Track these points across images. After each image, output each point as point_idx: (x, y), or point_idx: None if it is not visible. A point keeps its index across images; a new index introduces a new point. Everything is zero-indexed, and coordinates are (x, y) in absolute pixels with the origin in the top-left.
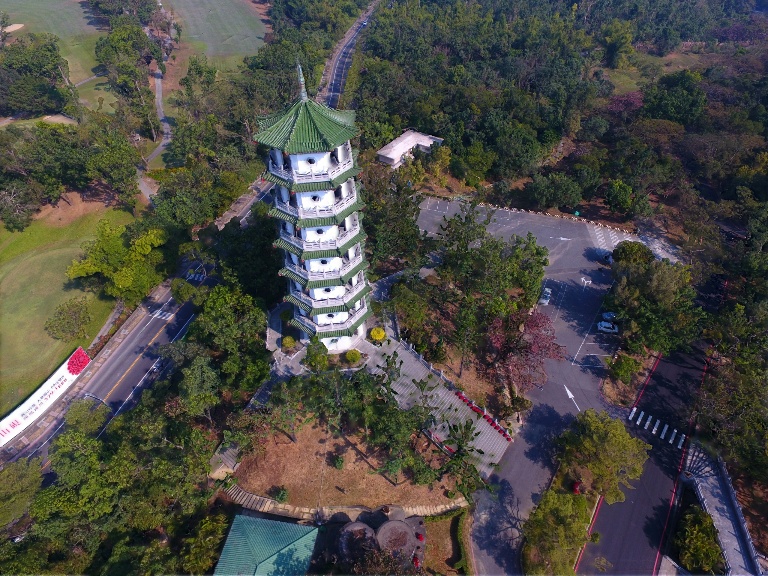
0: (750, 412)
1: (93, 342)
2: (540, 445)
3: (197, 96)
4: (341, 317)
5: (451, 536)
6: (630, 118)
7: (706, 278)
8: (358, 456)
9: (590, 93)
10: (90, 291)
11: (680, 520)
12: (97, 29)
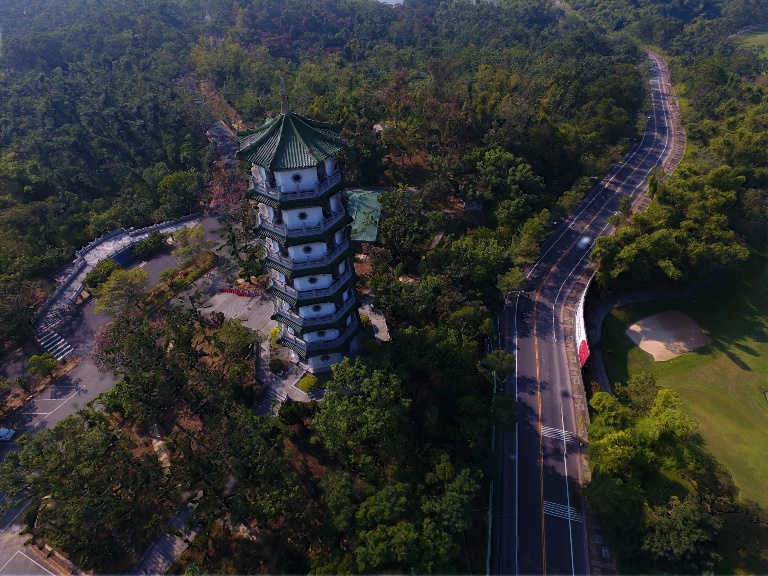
0: None
1: None
2: None
3: None
4: None
5: None
6: None
7: None
8: None
9: None
10: None
11: (104, 281)
12: None
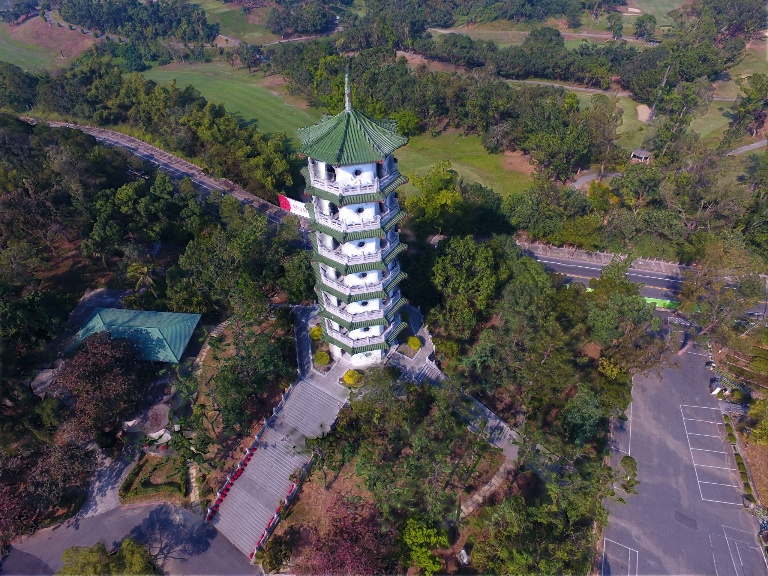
0: None
1: None
2: None
3: None
4: None
5: (168, 483)
6: None
7: None
8: None
9: None
10: None
11: None
12: None
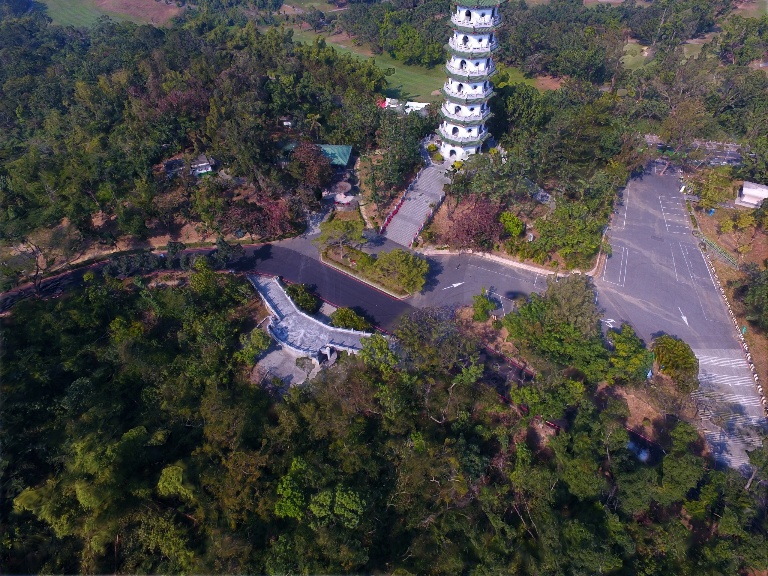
0: None
1: None
2: None
3: None
4: (448, 129)
5: None
6: None
7: None
8: None
9: None
10: None
11: None
12: None
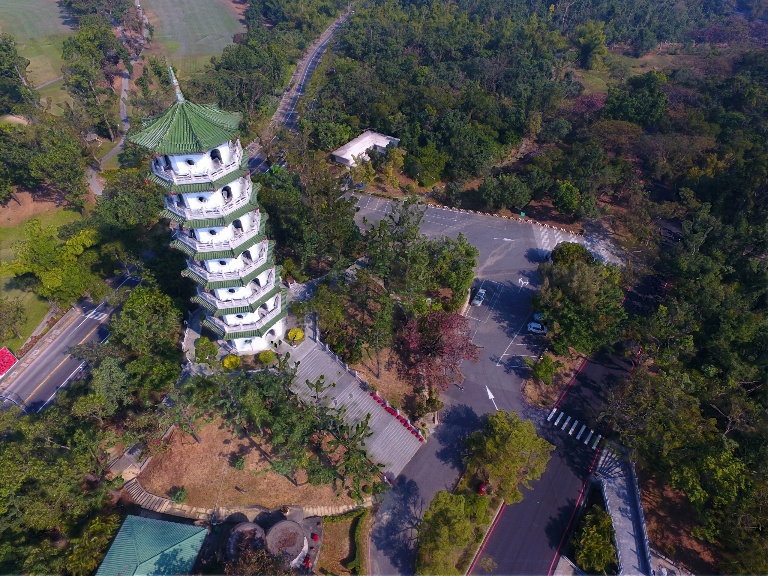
0: (653, 413)
1: (26, 342)
2: (453, 446)
3: (151, 96)
4: (251, 318)
5: (350, 536)
6: (592, 119)
7: (647, 279)
8: (262, 457)
9: (554, 94)
10: (30, 291)
11: (580, 520)
12: (71, 29)
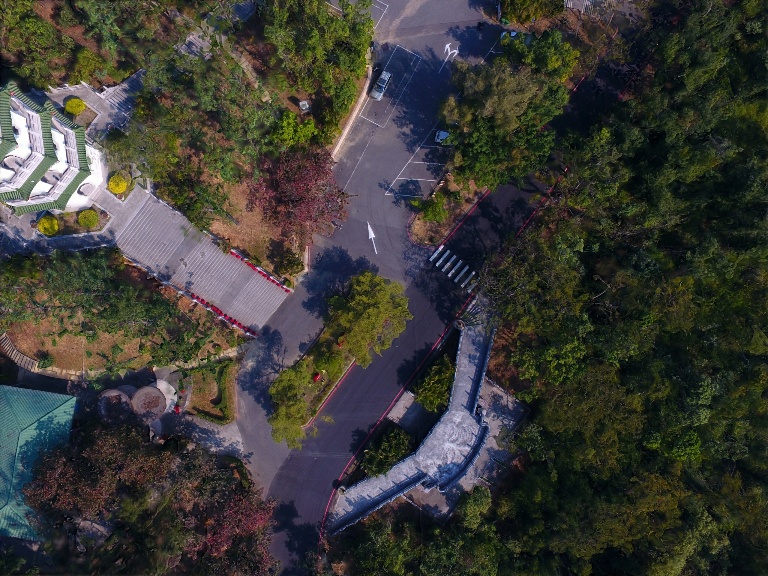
0: (519, 295)
1: None
2: (321, 295)
3: None
4: (37, 190)
5: None
6: None
7: None
8: None
9: None
10: None
11: (427, 369)
12: None
